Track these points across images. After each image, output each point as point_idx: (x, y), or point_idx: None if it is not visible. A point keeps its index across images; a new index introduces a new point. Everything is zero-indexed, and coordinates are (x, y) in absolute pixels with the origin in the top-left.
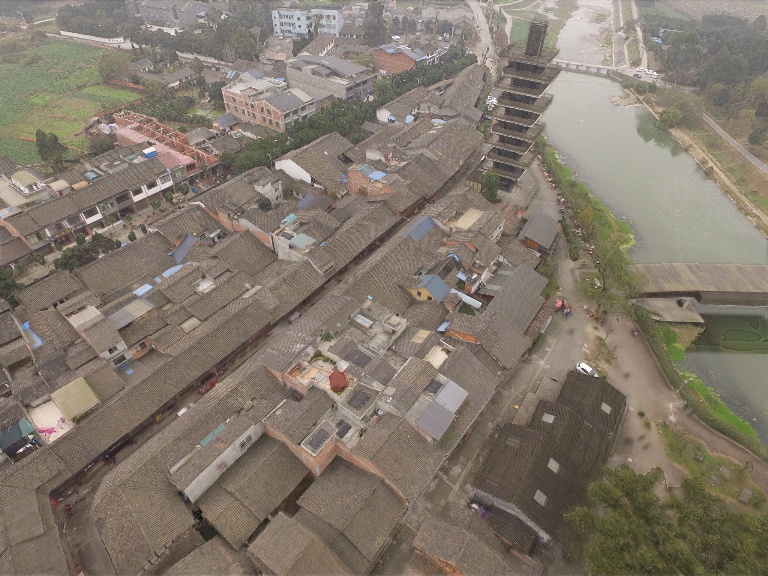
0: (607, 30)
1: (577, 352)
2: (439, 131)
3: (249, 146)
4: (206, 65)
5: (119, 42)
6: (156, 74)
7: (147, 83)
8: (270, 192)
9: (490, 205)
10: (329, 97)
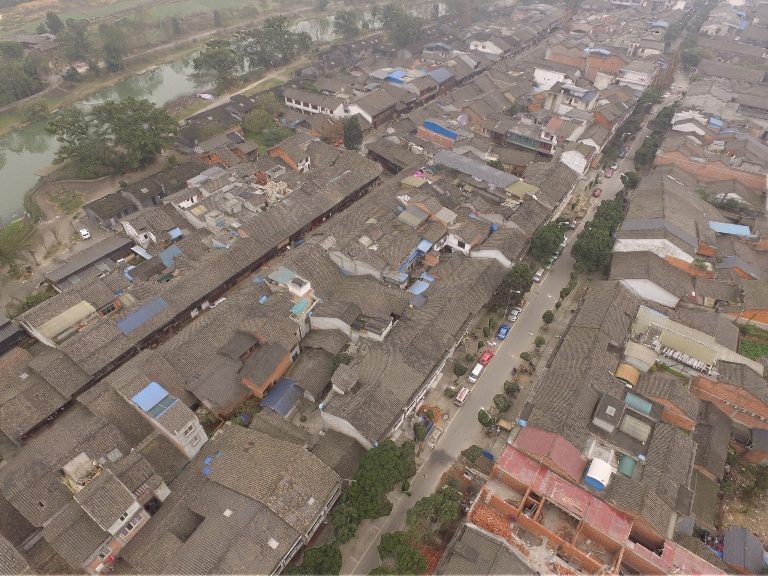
0: None
1: (77, 248)
2: None
3: None
4: None
5: None
6: None
7: None
8: None
9: None
10: None
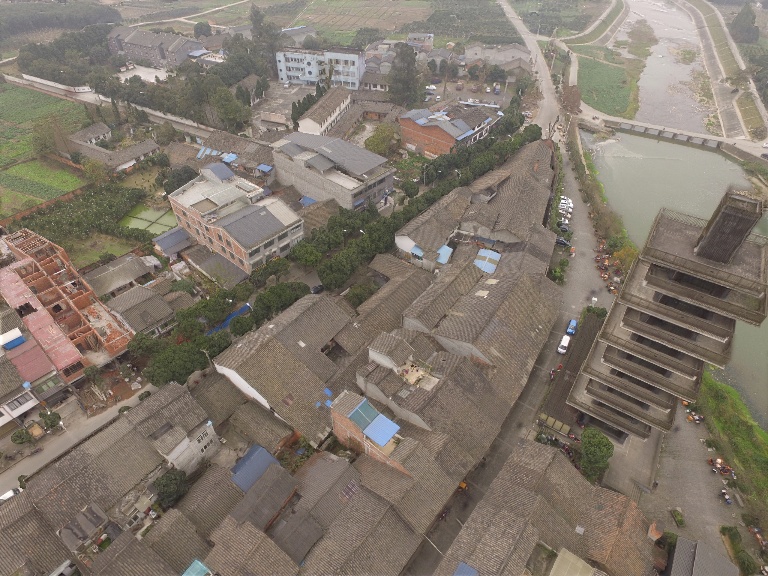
0: (701, 75)
1: None
2: (493, 296)
3: (182, 318)
4: (179, 132)
5: (87, 91)
6: (111, 145)
7: (86, 167)
8: (187, 450)
9: (591, 490)
10: (328, 203)
